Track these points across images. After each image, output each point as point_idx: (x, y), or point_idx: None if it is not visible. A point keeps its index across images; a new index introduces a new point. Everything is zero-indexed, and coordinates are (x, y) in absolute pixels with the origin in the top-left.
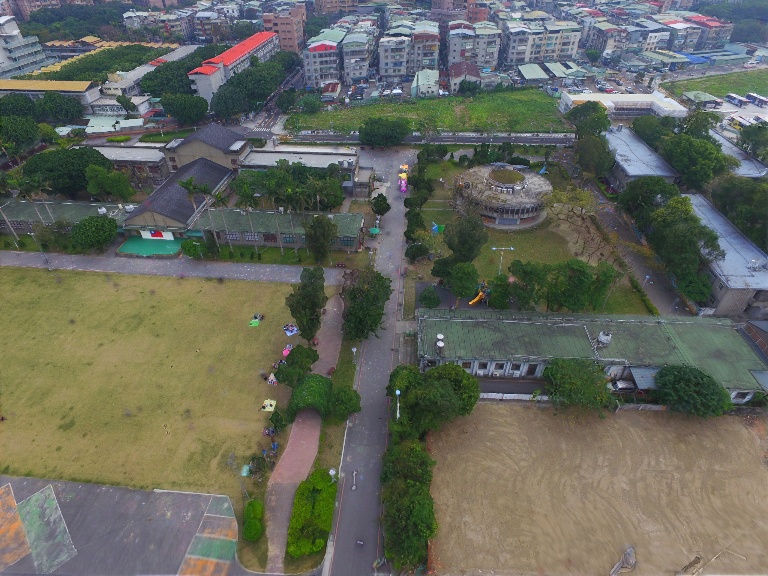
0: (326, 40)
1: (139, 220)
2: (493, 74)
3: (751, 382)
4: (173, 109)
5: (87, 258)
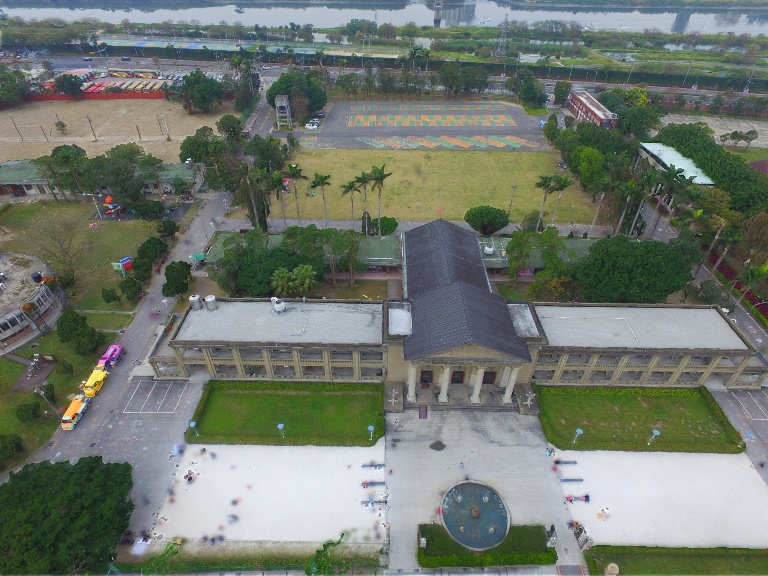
0: None
1: None
2: None
3: (26, 161)
4: None
5: None
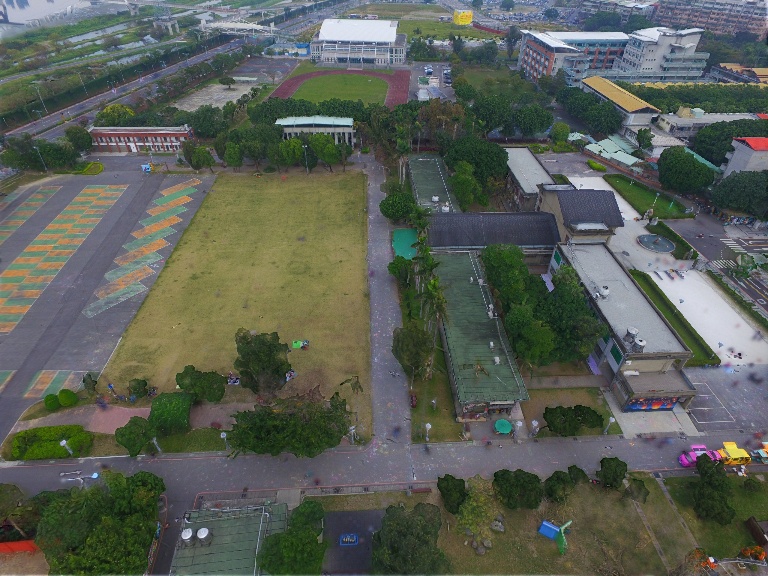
0: None
1: None
2: None
3: None
4: None
5: (385, 220)
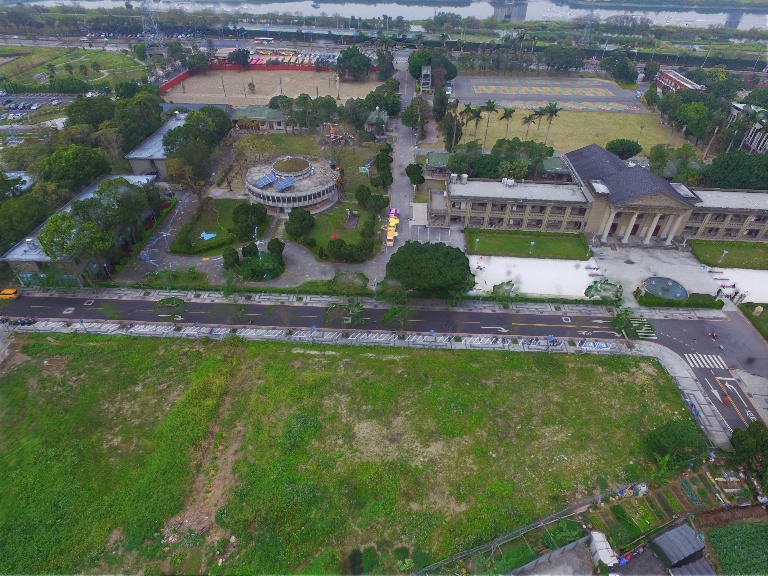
0: None
1: None
2: None
3: None
4: None
5: None
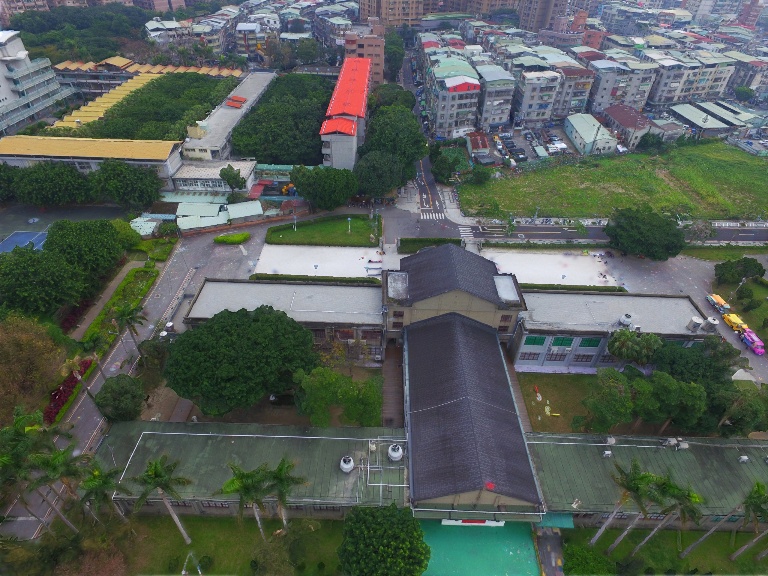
0: (463, 76)
1: (444, 497)
2: (670, 123)
3: None
4: (314, 191)
5: None
